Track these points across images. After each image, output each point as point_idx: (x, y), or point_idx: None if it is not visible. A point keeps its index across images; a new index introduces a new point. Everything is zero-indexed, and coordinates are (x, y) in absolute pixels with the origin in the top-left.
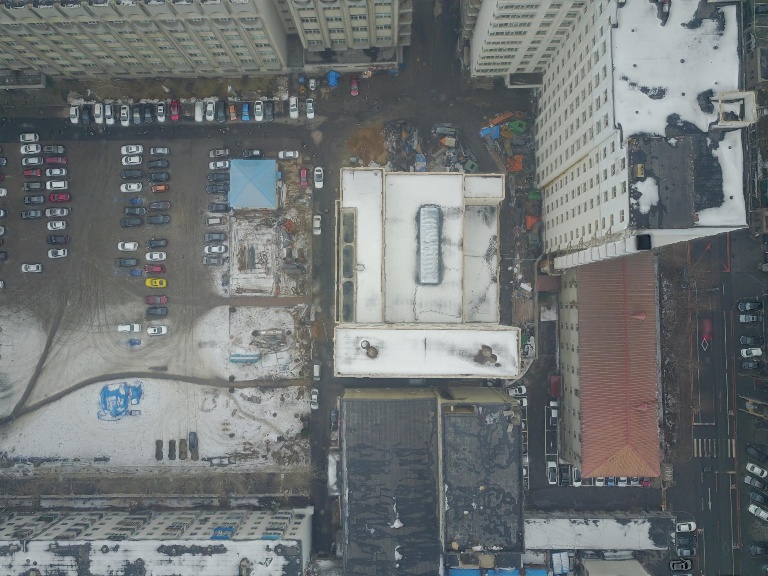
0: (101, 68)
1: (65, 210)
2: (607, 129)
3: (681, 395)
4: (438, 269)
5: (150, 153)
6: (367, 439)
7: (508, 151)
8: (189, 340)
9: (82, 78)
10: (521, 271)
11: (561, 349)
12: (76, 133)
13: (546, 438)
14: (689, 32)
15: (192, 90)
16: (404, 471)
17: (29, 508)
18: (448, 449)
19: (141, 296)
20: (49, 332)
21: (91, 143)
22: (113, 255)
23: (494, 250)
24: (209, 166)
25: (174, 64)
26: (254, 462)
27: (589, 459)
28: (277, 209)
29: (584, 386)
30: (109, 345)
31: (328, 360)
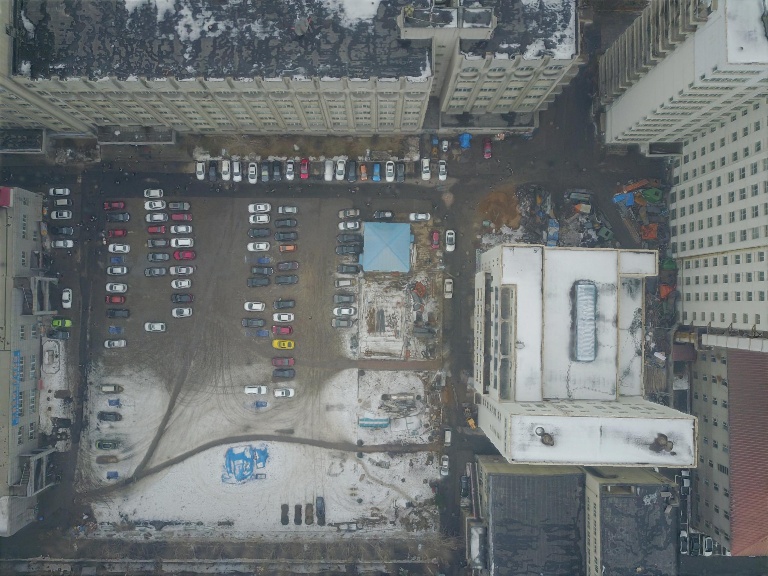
0: (235, 127)
1: (191, 268)
2: None
3: None
4: (594, 347)
5: (278, 212)
6: (514, 514)
7: (644, 219)
8: (316, 403)
9: (209, 133)
10: (654, 339)
11: None
12: (202, 189)
13: None
14: None
15: (321, 148)
16: (551, 547)
17: (151, 573)
18: (605, 529)
19: (267, 357)
20: (172, 393)
21: (217, 200)
22: (239, 315)
23: (638, 323)
24: (339, 226)
25: (311, 125)
26: (382, 528)
27: (739, 538)
28: (408, 272)
29: (735, 465)
30: (234, 407)
31: (458, 425)
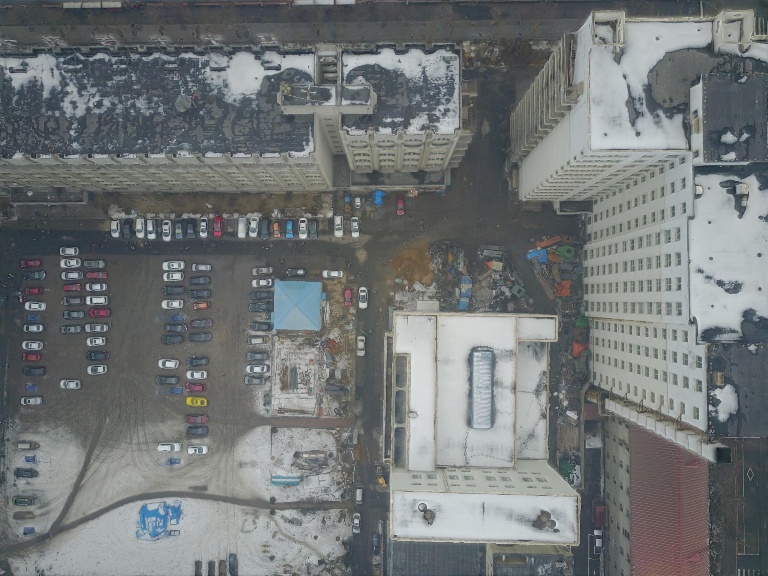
0: (145, 187)
1: (105, 326)
2: (680, 319)
3: (726, 525)
4: (491, 415)
5: (192, 269)
6: None
7: (556, 277)
8: (230, 460)
9: (123, 191)
10: (567, 397)
11: (606, 478)
12: (117, 247)
13: (589, 566)
14: (767, 225)
15: (235, 205)
16: None
17: None
18: None
19: (181, 414)
20: (88, 449)
21: (132, 257)
22: (153, 372)
23: (544, 386)
24: (252, 284)
25: (219, 185)
26: None
27: None
28: (321, 329)
29: (635, 532)
30: (148, 463)
31: (370, 483)
